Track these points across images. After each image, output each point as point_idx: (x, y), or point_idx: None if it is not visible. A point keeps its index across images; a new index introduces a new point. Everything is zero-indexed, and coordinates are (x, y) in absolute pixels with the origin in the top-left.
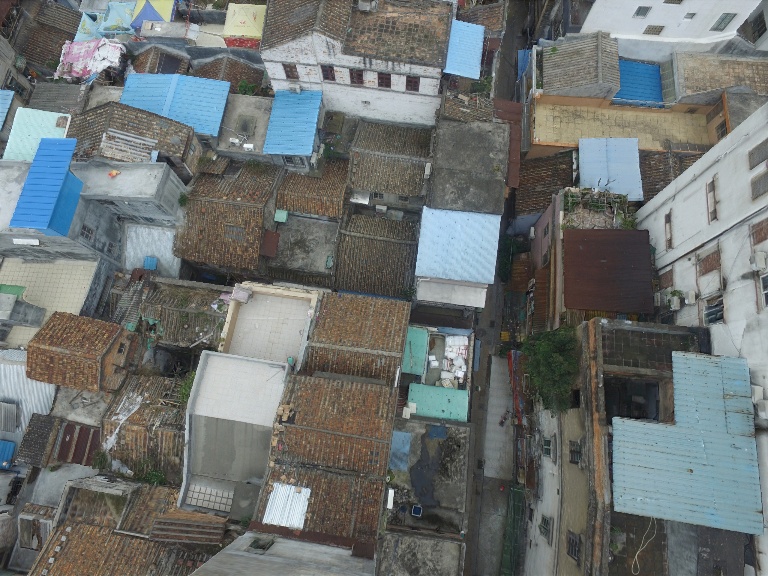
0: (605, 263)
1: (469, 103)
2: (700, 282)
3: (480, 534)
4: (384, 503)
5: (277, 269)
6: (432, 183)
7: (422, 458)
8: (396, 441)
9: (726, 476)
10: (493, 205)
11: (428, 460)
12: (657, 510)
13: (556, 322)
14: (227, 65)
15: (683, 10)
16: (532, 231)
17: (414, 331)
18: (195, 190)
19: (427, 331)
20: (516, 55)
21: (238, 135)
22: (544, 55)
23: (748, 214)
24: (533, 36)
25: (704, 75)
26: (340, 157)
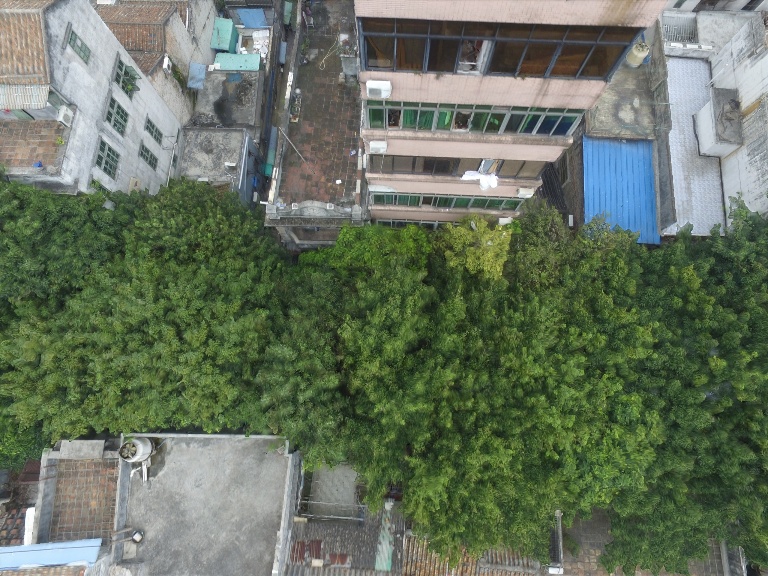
0: None
1: None
2: None
3: None
4: (161, 66)
5: None
6: None
7: (223, 95)
8: (193, 69)
9: None
10: None
11: (228, 96)
12: None
13: None
14: None
15: None
16: None
17: (221, 20)
18: None
19: (232, 21)
20: None
21: None
22: None
23: None
24: None
25: None
26: None
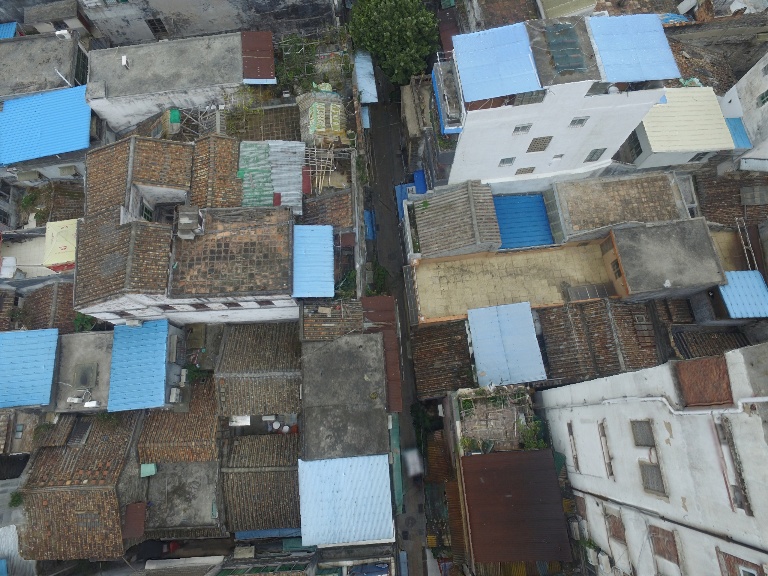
0: (511, 498)
1: (332, 314)
2: (612, 546)
3: None
4: None
5: (156, 530)
6: (303, 430)
7: None
8: None
9: None
10: (376, 444)
11: None
12: None
13: (472, 565)
14: (59, 292)
15: (549, 154)
16: (440, 410)
17: None
18: (32, 477)
19: None
20: (394, 193)
21: (77, 390)
22: (416, 211)
23: (642, 505)
24: (408, 169)
25: (589, 205)
26: (211, 370)
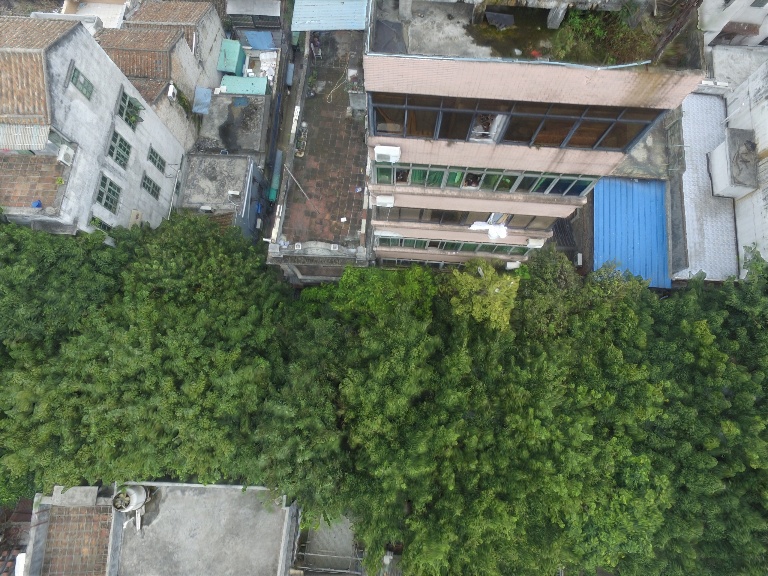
0: None
1: None
2: None
3: None
4: (166, 94)
5: None
6: None
7: (228, 119)
8: (199, 94)
9: (365, 2)
10: None
11: (233, 120)
12: (318, 26)
13: None
14: None
15: None
16: None
17: (228, 42)
18: None
19: (239, 42)
20: None
21: None
22: None
23: None
24: None
25: None
26: None
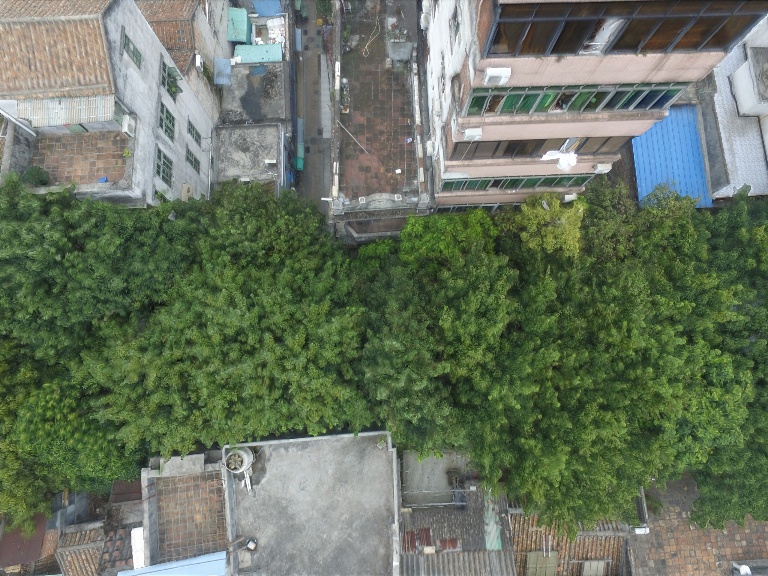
0: None
1: None
2: None
3: (324, 177)
4: (194, 65)
5: None
6: None
7: (249, 90)
8: (218, 64)
9: None
10: None
11: (254, 90)
12: None
13: None
14: None
15: None
16: None
17: (234, 11)
18: None
19: (245, 10)
20: None
21: None
22: None
23: None
24: None
25: None
26: None
